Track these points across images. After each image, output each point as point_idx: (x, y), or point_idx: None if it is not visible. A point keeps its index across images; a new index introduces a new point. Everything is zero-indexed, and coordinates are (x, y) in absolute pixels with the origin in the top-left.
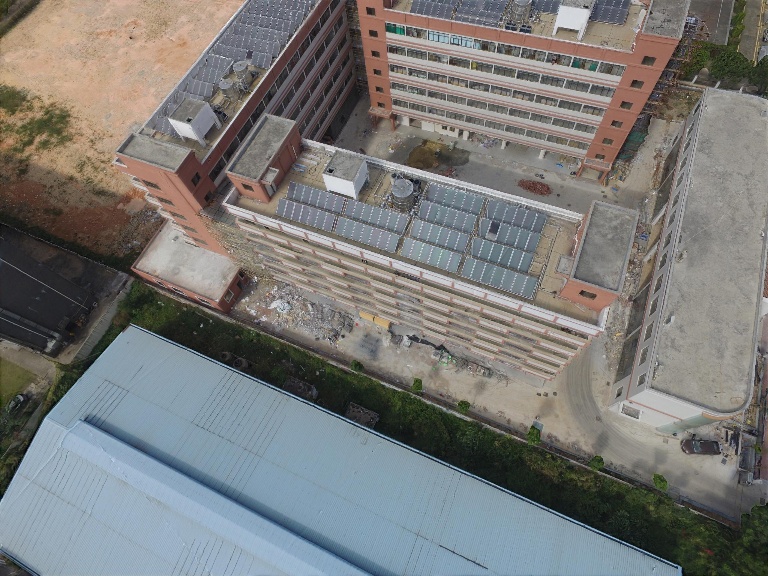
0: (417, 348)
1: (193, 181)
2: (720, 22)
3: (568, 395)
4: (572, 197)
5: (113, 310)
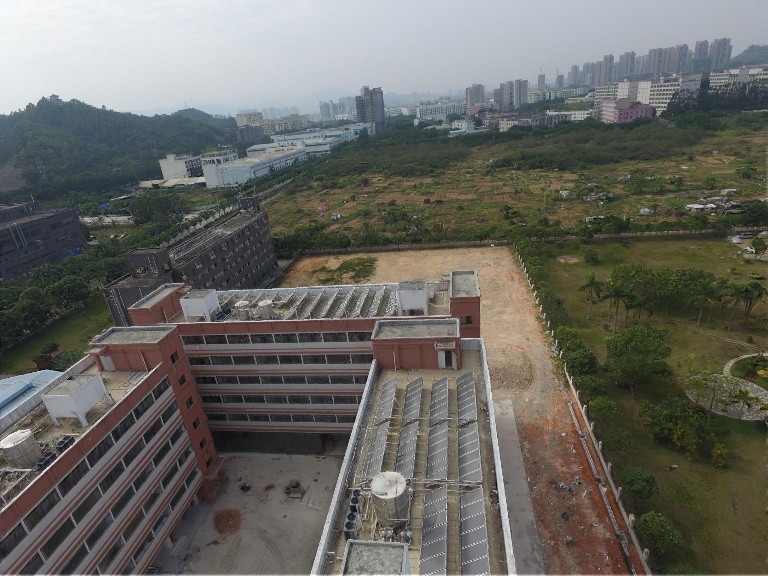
0: None
1: None
2: None
3: None
4: None
5: None
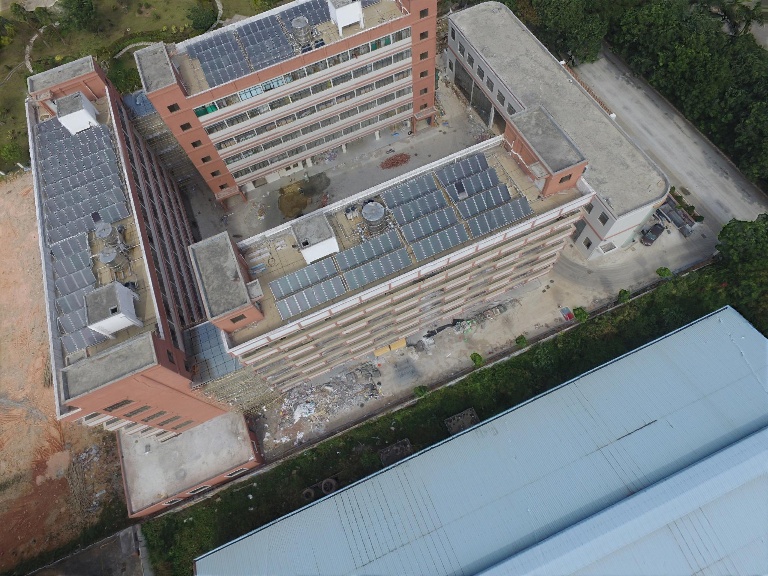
0: (440, 338)
1: (170, 361)
2: None
3: (559, 275)
4: (426, 149)
5: (148, 574)
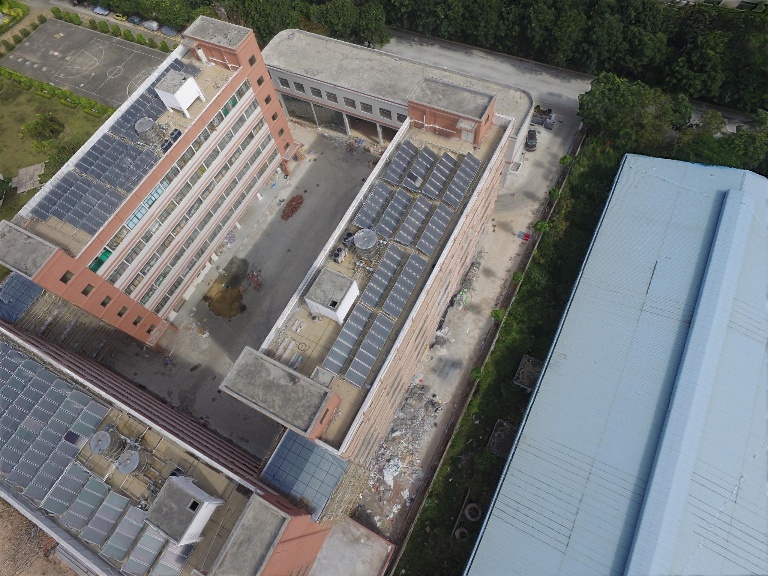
0: (450, 323)
1: None
2: (162, 58)
3: (494, 211)
4: (310, 182)
5: None
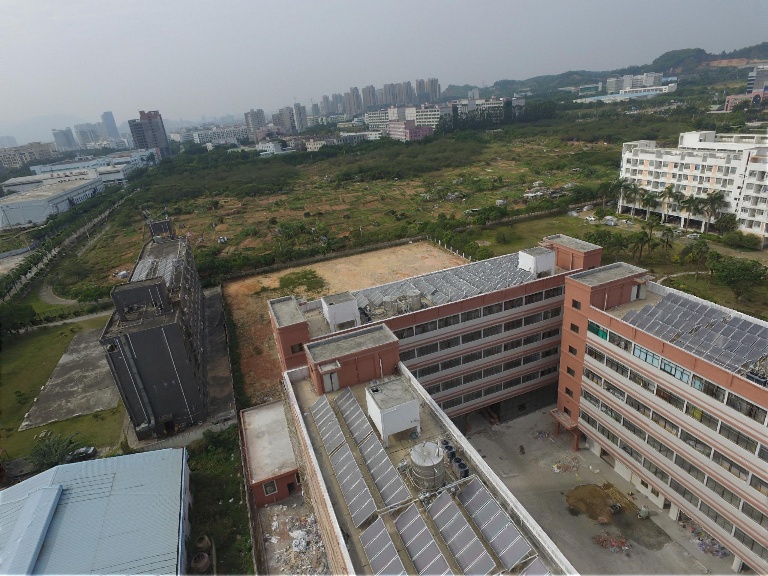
0: None
1: (293, 348)
2: None
3: None
4: None
5: (201, 434)
